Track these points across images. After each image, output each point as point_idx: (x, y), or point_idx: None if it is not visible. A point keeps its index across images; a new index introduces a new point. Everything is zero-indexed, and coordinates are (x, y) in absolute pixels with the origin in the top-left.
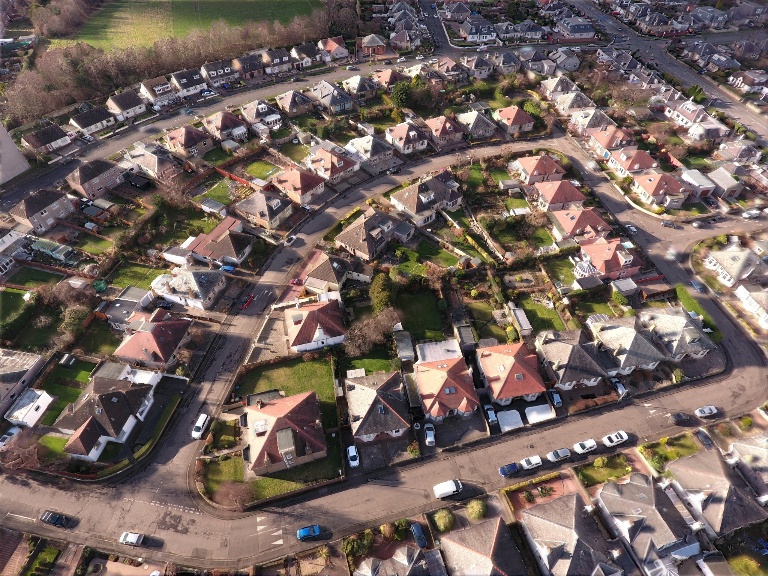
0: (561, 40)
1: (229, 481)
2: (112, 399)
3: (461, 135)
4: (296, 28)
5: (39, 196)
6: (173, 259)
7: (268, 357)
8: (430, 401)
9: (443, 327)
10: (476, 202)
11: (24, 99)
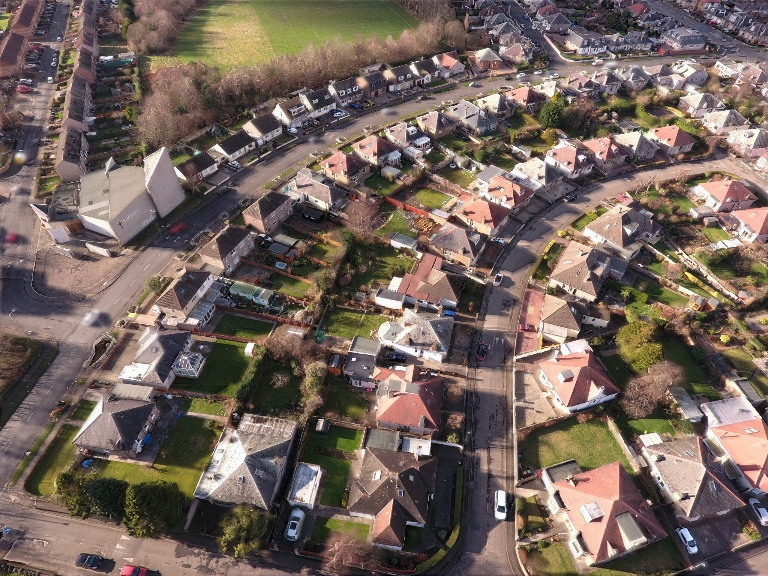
0: (673, 52)
1: (562, 574)
2: (409, 477)
3: (624, 157)
4: (410, 43)
5: (228, 234)
6: (385, 303)
7: (536, 418)
8: (756, 473)
9: (708, 379)
10: (674, 233)
11: (162, 124)
